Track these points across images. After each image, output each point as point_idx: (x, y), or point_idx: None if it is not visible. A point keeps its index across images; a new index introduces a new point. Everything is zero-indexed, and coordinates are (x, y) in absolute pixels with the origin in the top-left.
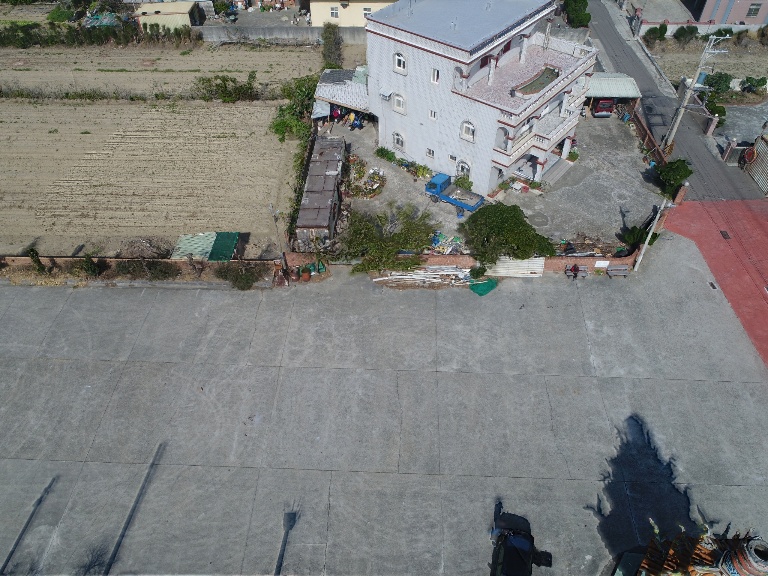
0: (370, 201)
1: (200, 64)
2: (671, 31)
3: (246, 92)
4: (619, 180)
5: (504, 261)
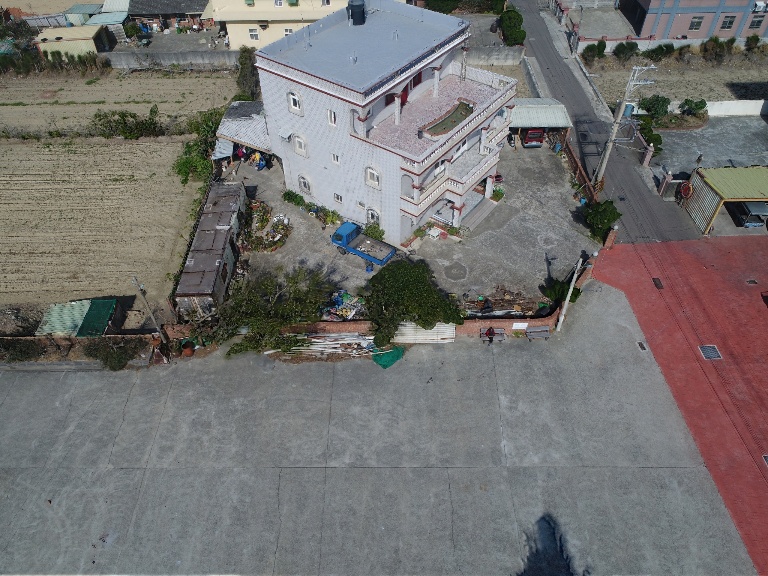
0: (271, 255)
1: (106, 94)
2: (610, 47)
3: (149, 128)
4: (547, 221)
5: (410, 327)
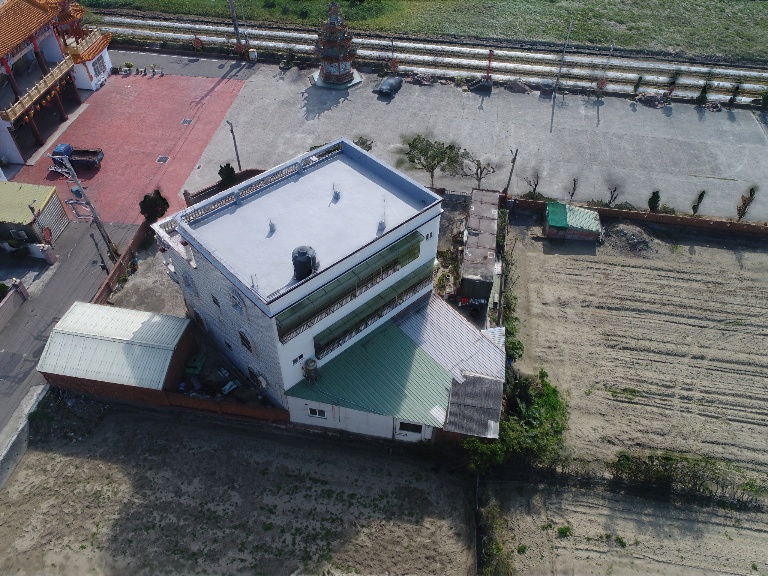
0: None
1: None
2: None
3: None
4: None
5: None
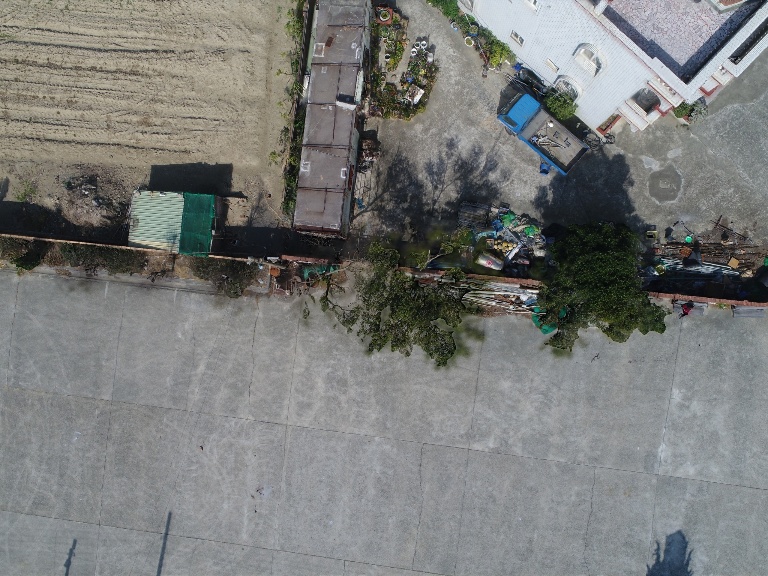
0: (408, 125)
1: None
2: None
3: None
4: None
5: None
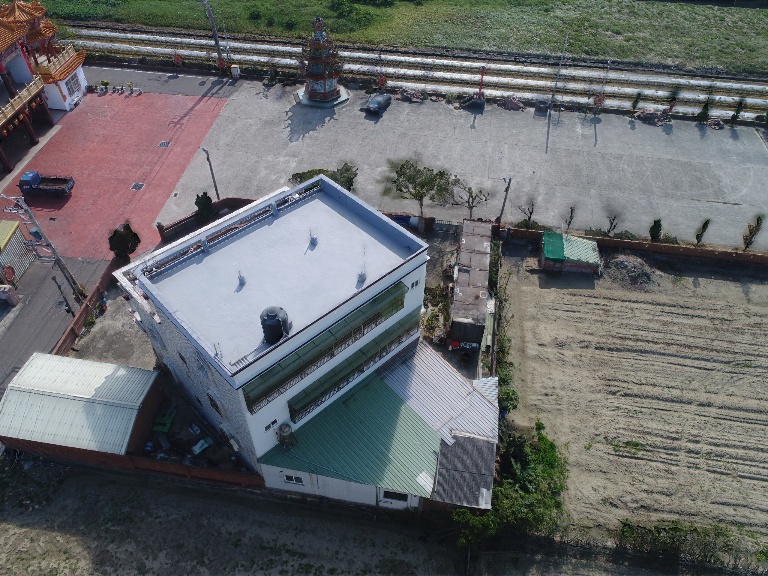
0: None
1: None
2: None
3: None
4: None
5: None
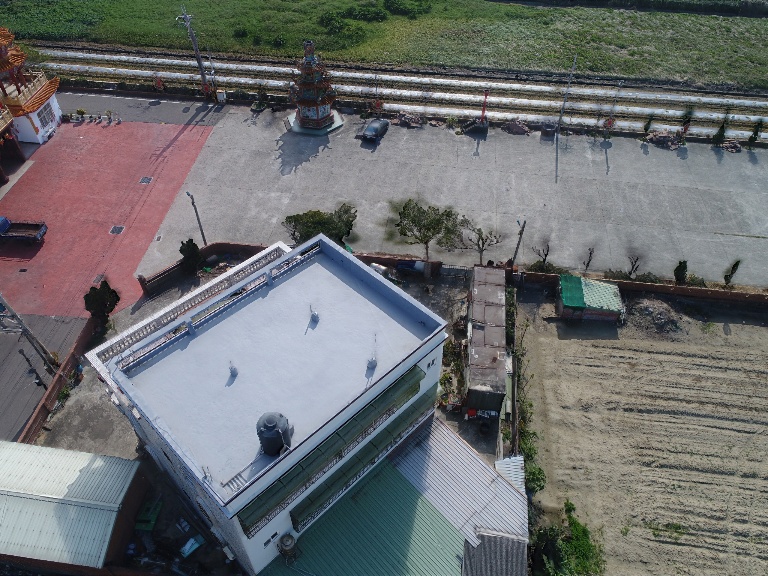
0: None
1: None
2: None
3: None
4: None
5: None
